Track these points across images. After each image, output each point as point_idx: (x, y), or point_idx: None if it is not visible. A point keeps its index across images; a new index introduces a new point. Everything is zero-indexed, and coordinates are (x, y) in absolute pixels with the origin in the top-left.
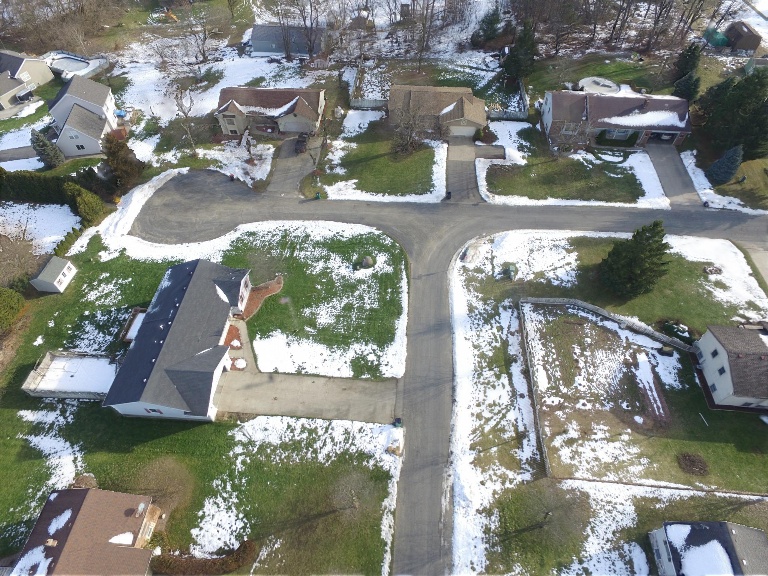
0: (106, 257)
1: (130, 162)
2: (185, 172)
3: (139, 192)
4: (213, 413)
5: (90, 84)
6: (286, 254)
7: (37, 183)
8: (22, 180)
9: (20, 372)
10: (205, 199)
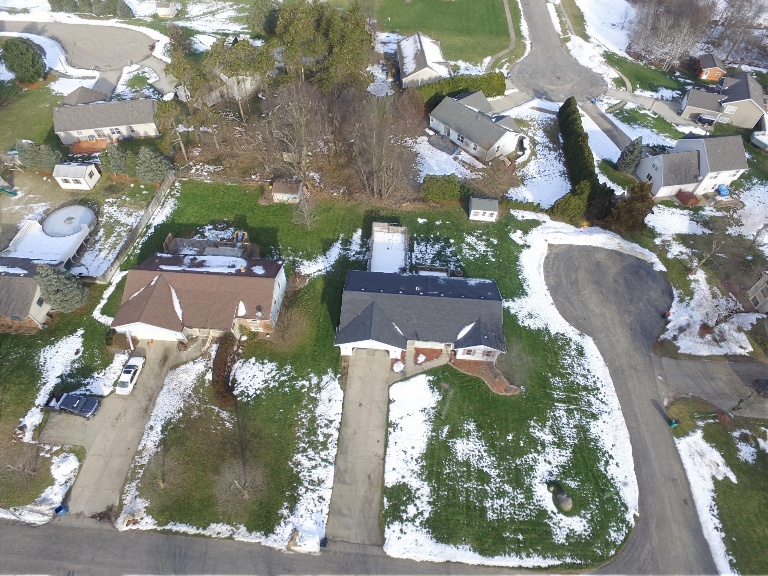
0: (516, 236)
1: (633, 215)
2: (656, 268)
3: (607, 237)
4: (345, 352)
5: (737, 151)
6: (557, 394)
7: (582, 164)
8: (581, 154)
9: (393, 219)
10: (620, 296)
